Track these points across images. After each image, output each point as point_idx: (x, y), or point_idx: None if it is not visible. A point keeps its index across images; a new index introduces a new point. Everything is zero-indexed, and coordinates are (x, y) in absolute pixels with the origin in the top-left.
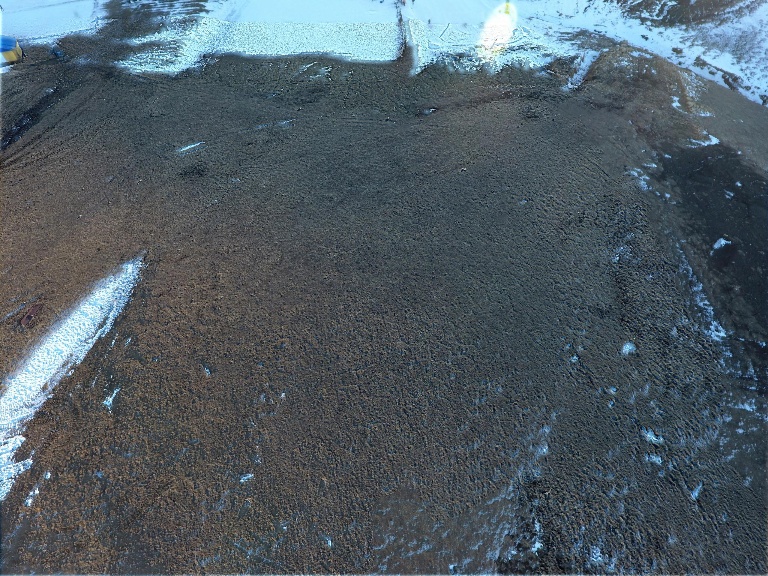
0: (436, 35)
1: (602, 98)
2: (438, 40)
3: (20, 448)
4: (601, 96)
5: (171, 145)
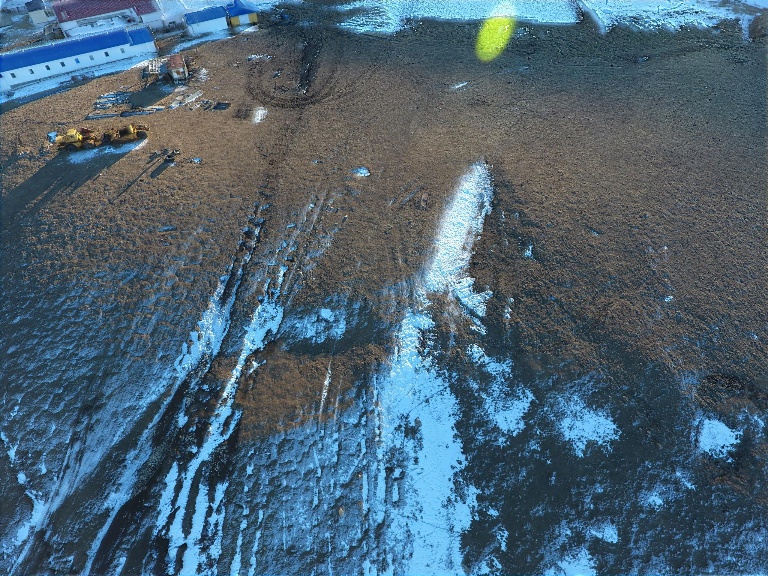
0: (602, 3)
1: None
2: (607, 6)
3: (475, 284)
4: None
5: (444, 84)
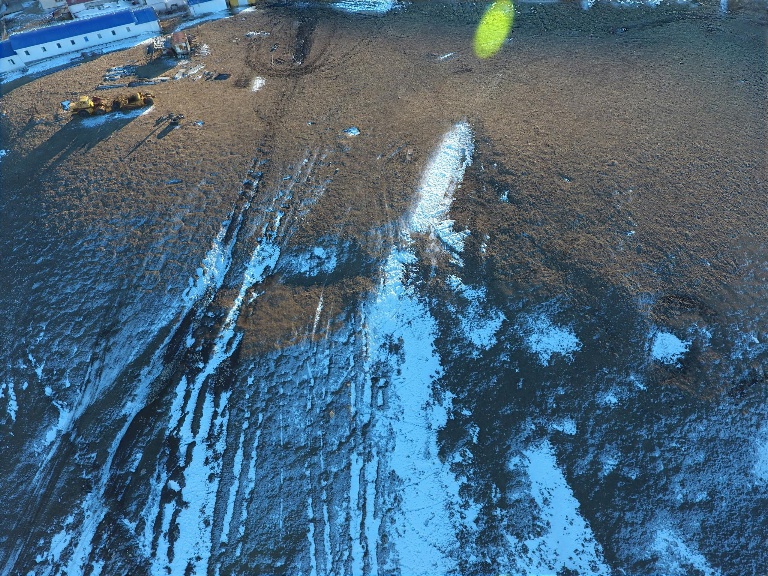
0: None
1: (758, 20)
2: None
3: (455, 225)
4: (756, 18)
5: (431, 55)
